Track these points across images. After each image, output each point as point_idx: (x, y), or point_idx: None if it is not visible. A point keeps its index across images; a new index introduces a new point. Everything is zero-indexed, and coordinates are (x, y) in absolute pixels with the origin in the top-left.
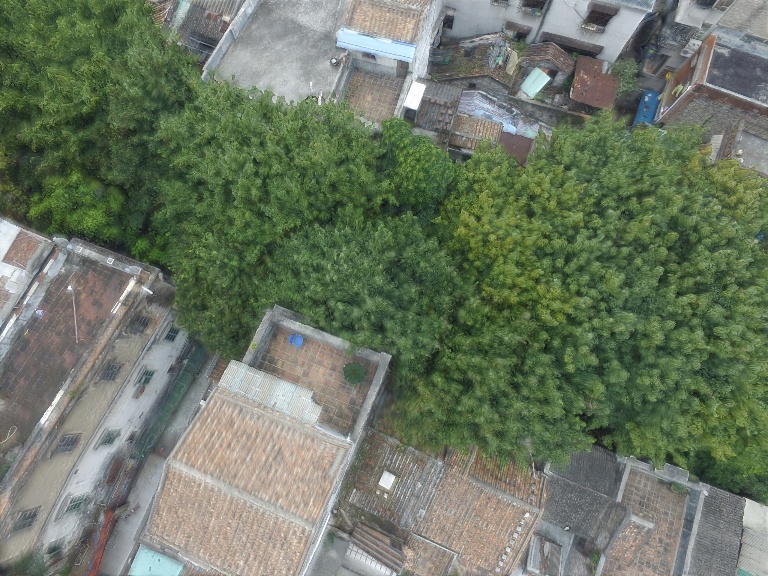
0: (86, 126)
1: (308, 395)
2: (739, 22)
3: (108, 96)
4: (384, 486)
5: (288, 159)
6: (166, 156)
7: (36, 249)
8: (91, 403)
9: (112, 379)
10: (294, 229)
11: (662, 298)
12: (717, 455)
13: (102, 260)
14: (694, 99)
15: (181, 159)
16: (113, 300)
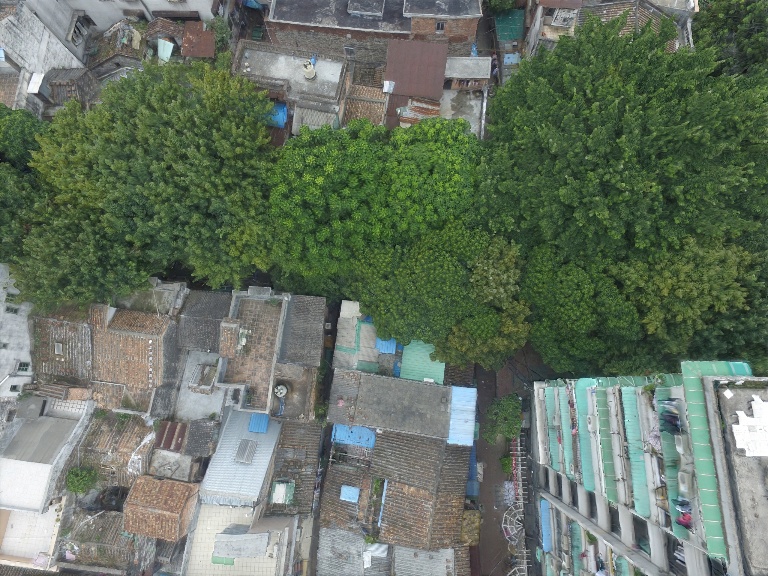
0: None
1: None
2: None
3: None
4: (59, 353)
5: None
6: None
7: None
8: None
9: None
10: None
11: None
12: (257, 266)
13: None
14: (275, 33)
15: None
16: None
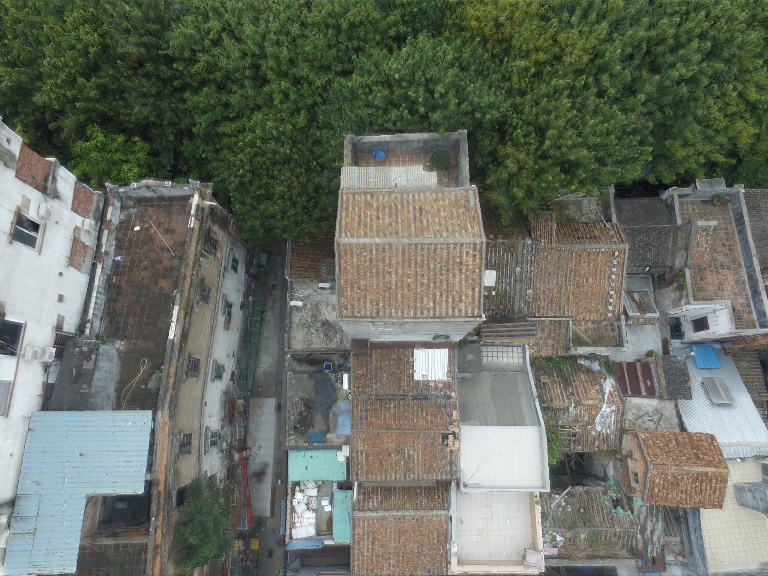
0: (92, 75)
1: (419, 169)
2: None
3: (105, 35)
4: (489, 285)
5: (299, 23)
6: (183, 68)
7: (92, 201)
8: (198, 326)
9: (206, 303)
10: (329, 82)
11: (658, 10)
12: (743, 141)
13: (160, 185)
14: None
15: (201, 59)
16: (182, 223)
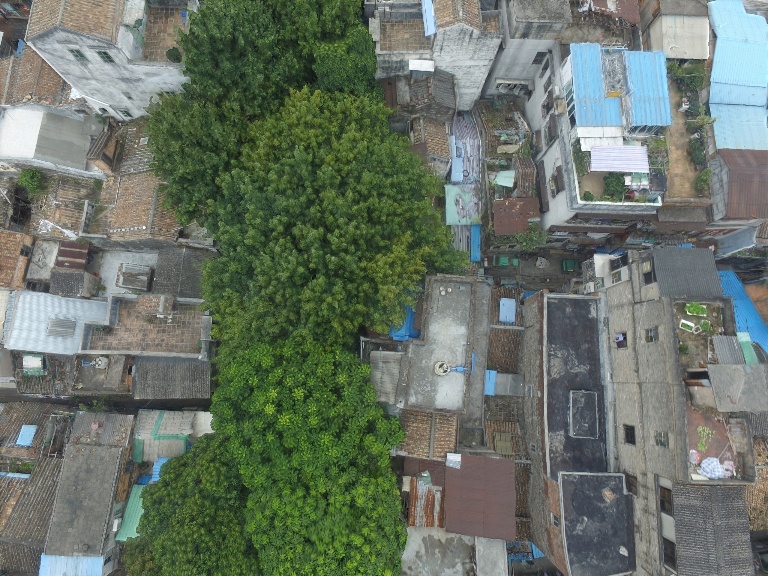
0: None
1: (140, 17)
2: (612, 303)
3: None
4: (140, 142)
5: None
6: None
7: None
8: None
9: None
10: (265, 2)
11: None
12: None
13: None
14: None
15: None
16: None
